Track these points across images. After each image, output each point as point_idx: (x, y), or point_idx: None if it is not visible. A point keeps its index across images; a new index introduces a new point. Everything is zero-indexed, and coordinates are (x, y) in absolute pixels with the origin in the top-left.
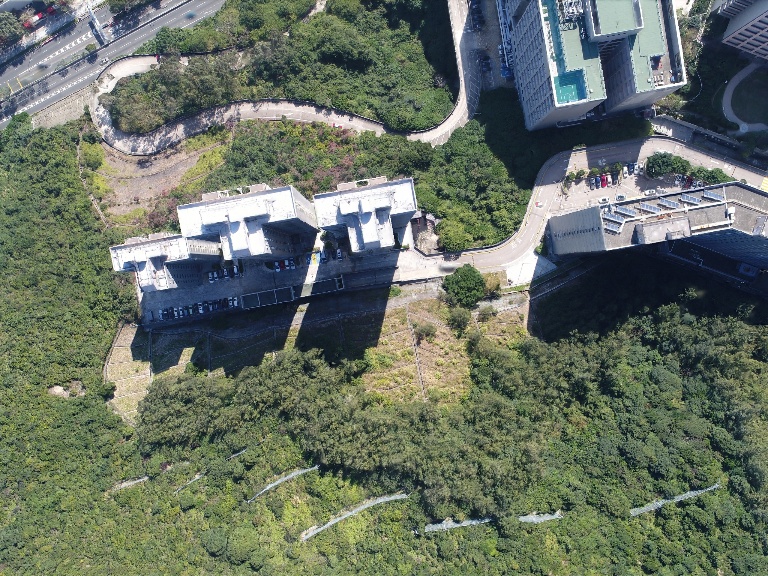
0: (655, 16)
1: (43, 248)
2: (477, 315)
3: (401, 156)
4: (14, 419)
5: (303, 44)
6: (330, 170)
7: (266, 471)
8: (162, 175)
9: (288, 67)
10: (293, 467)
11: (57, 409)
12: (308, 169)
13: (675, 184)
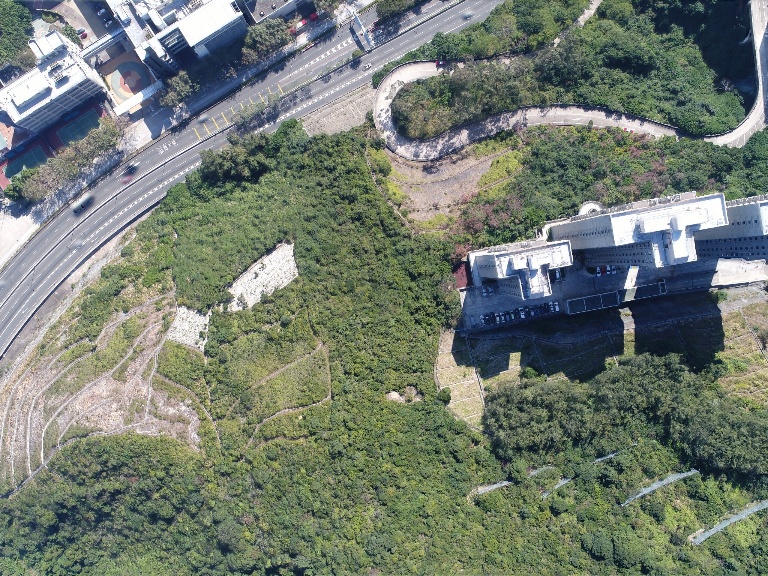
0: None
1: (347, 254)
2: None
3: (714, 161)
4: (362, 425)
5: (586, 49)
6: (645, 175)
7: (640, 475)
8: (454, 181)
9: (579, 72)
10: (666, 471)
11: (402, 415)
12: None
13: None
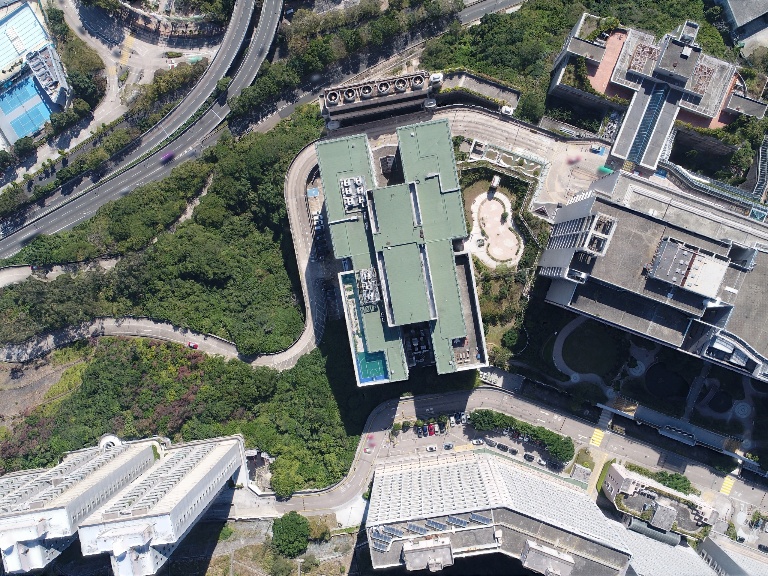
0: (456, 299)
1: None
2: (301, 563)
3: (240, 392)
4: None
5: (165, 259)
6: (172, 405)
7: None
8: (29, 389)
9: (146, 287)
10: None
11: None
12: (149, 406)
13: (503, 434)
